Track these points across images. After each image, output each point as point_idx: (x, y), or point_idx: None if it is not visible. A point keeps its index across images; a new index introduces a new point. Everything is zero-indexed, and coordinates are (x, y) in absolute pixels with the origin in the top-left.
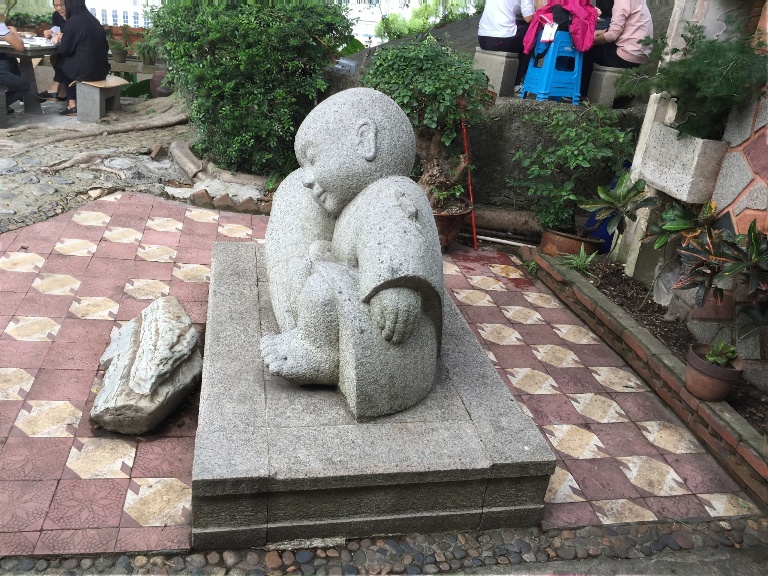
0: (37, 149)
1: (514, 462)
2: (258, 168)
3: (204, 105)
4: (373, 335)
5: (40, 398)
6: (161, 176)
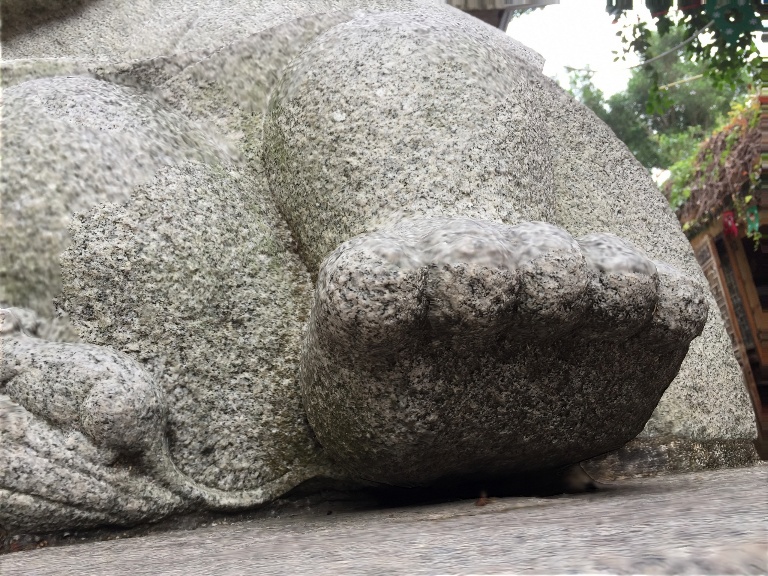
0: None
1: None
2: None
3: None
4: None
5: None
6: None
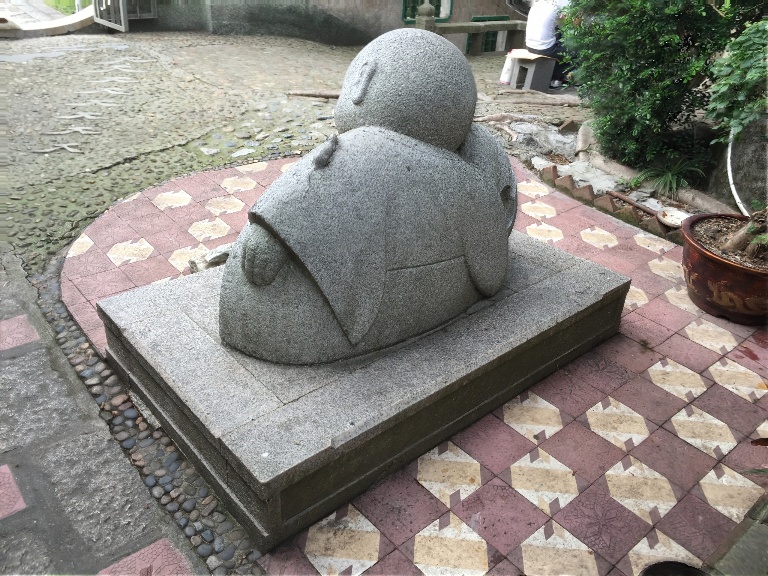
0: (481, 104)
1: (232, 451)
2: (634, 161)
3: (578, 77)
4: (239, 264)
5: (208, 246)
6: (554, 149)
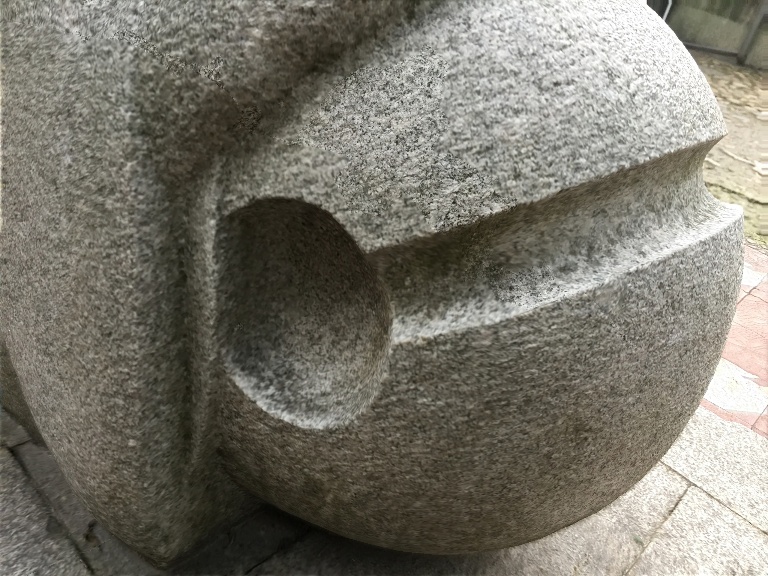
0: None
1: None
2: None
3: None
4: None
5: None
6: None
